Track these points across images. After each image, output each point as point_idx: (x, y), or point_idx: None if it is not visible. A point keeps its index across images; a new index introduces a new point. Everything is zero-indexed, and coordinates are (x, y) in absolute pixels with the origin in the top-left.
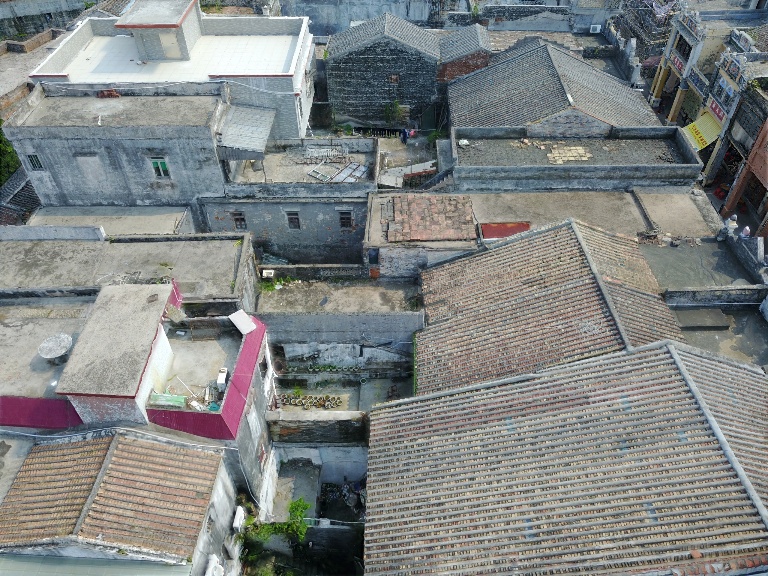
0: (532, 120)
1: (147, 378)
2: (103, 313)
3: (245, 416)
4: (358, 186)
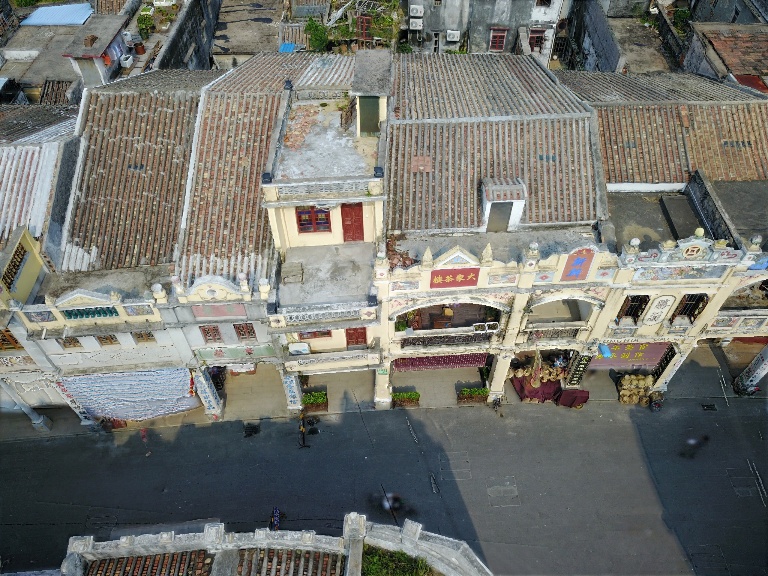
0: None
1: None
2: None
3: None
4: None
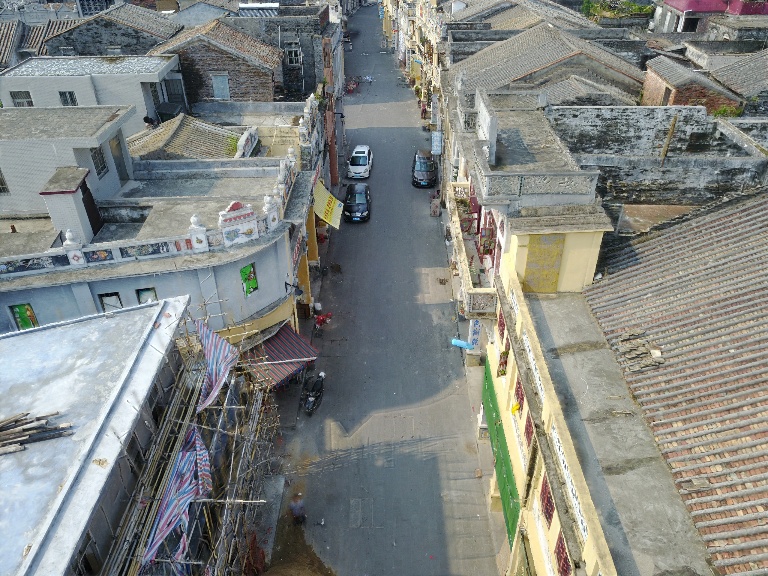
0: None
1: None
2: None
3: None
4: (695, 44)
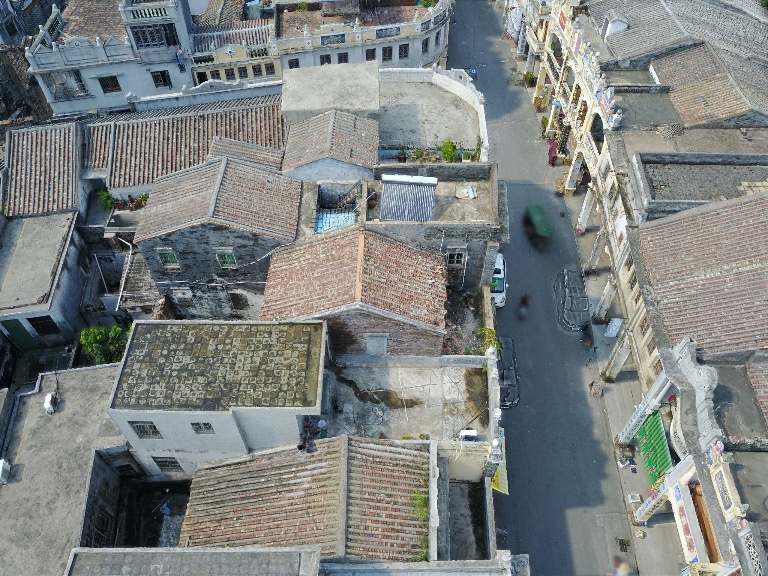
0: None
1: None
2: None
3: None
4: None
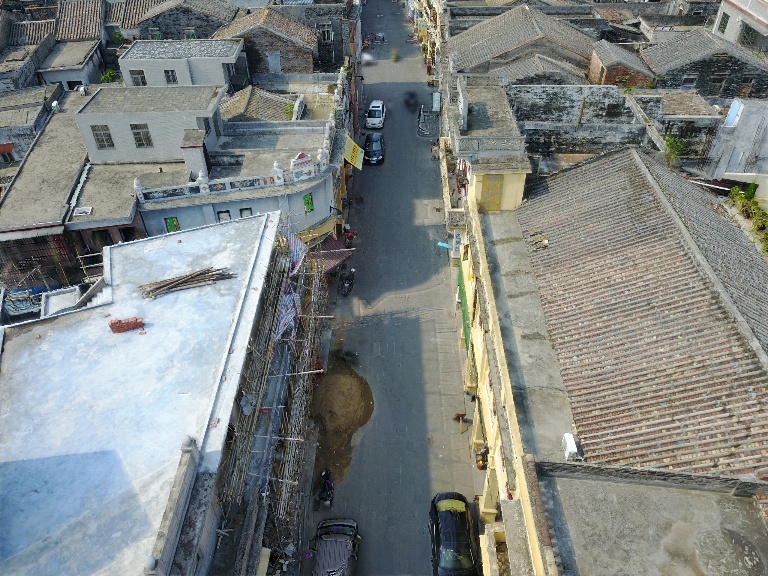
0: (550, 17)
1: None
2: None
3: None
4: (649, 18)
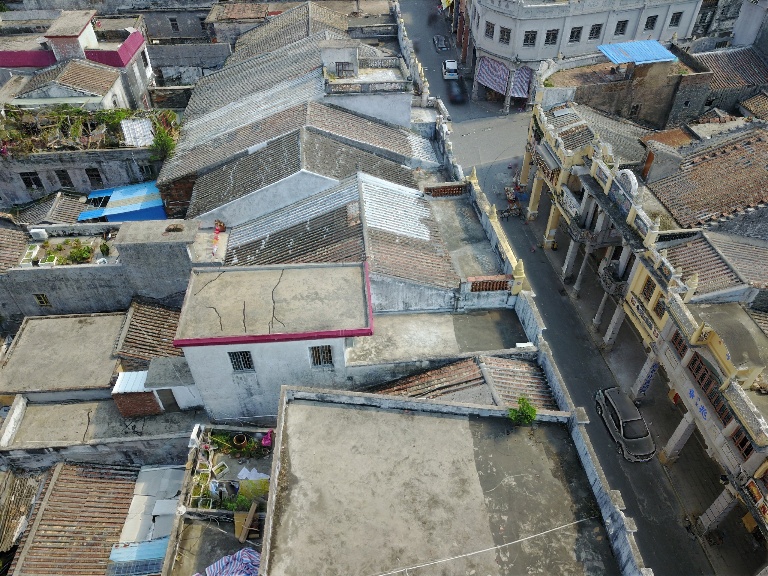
0: None
1: (84, 39)
2: (64, 17)
3: (132, 66)
4: None
